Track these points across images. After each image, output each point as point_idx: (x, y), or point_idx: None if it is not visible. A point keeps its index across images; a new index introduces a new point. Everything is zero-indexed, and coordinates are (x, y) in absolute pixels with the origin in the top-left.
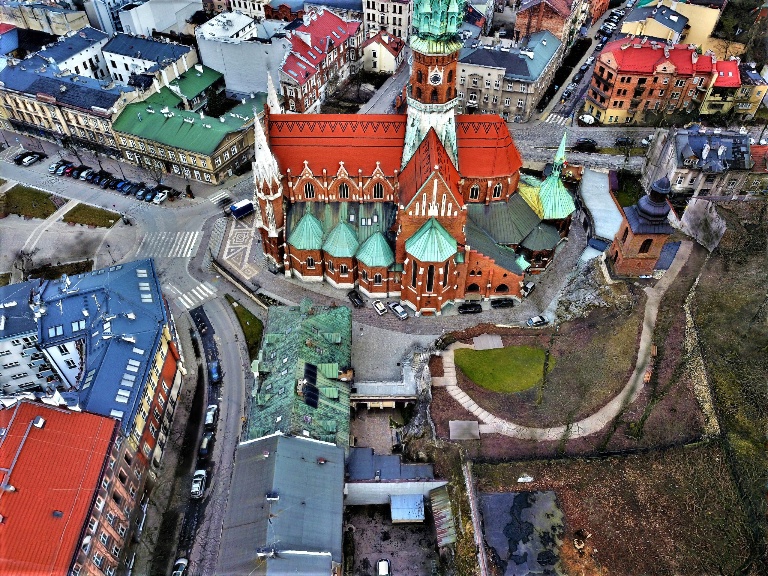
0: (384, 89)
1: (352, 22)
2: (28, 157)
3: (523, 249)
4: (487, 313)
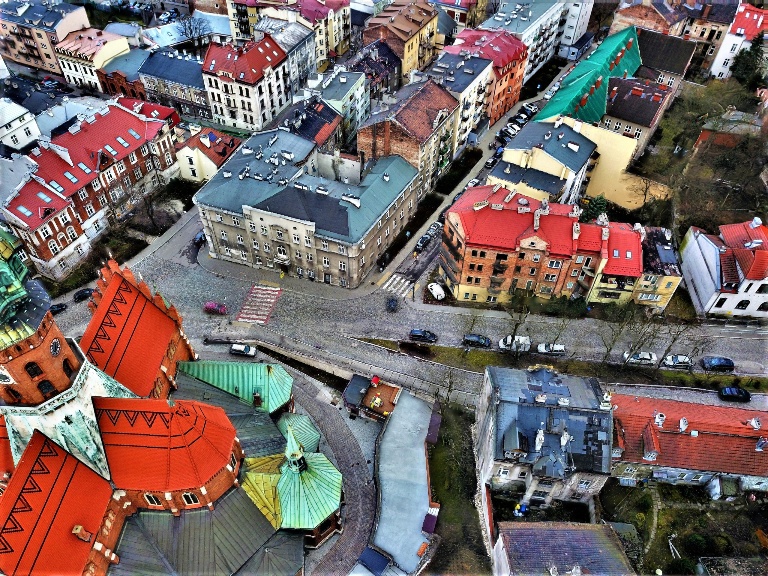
0: (196, 211)
1: (153, 121)
2: None
3: None
4: None
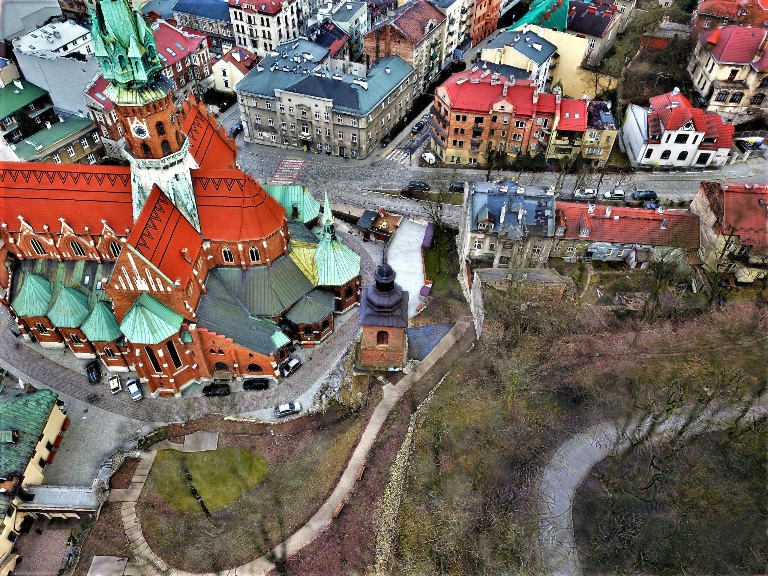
0: (230, 112)
1: (194, 37)
2: None
3: (288, 321)
4: (235, 396)
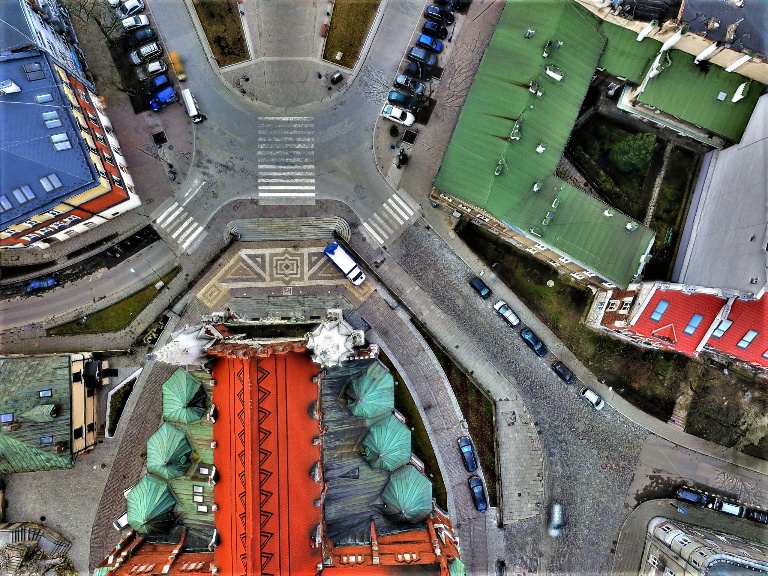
0: (746, 464)
1: None
2: None
3: None
4: None
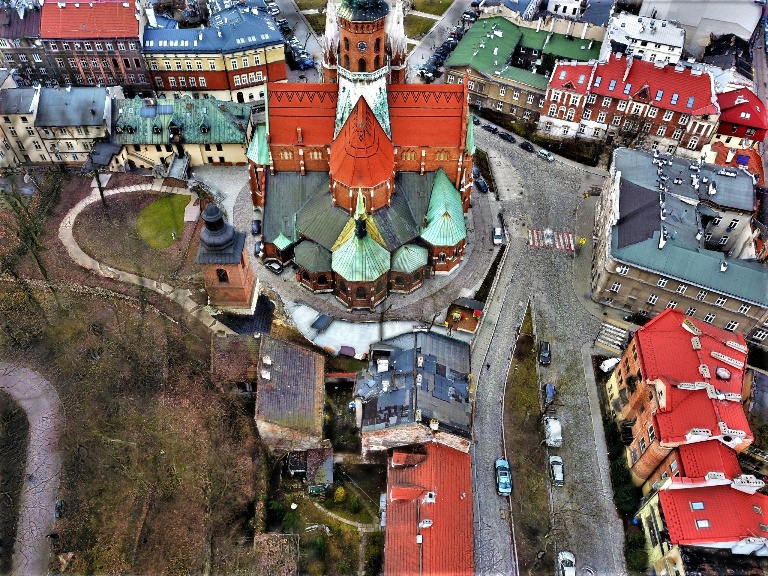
0: None
1: (716, 107)
2: (468, 15)
3: None
4: (252, 239)
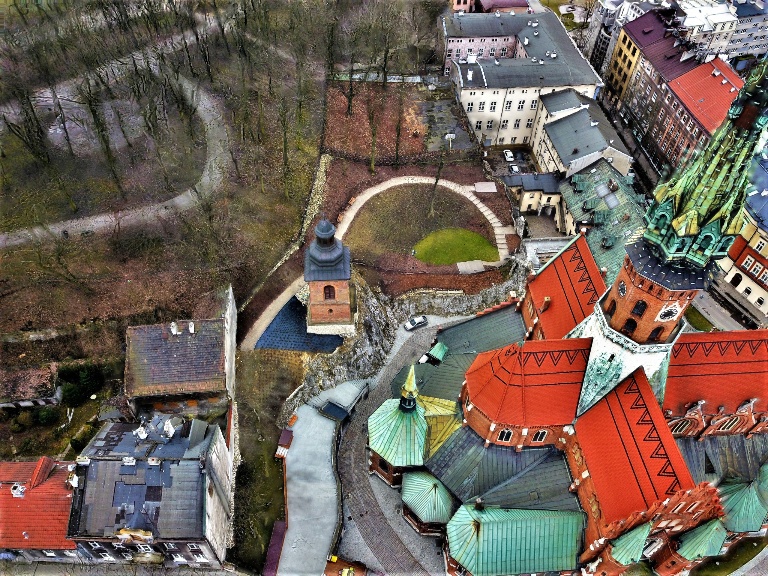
0: None
1: None
2: None
3: None
4: None
